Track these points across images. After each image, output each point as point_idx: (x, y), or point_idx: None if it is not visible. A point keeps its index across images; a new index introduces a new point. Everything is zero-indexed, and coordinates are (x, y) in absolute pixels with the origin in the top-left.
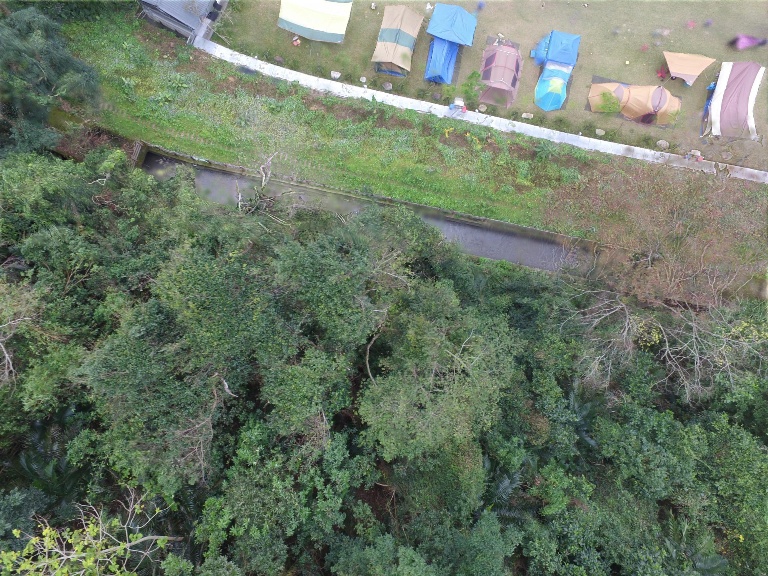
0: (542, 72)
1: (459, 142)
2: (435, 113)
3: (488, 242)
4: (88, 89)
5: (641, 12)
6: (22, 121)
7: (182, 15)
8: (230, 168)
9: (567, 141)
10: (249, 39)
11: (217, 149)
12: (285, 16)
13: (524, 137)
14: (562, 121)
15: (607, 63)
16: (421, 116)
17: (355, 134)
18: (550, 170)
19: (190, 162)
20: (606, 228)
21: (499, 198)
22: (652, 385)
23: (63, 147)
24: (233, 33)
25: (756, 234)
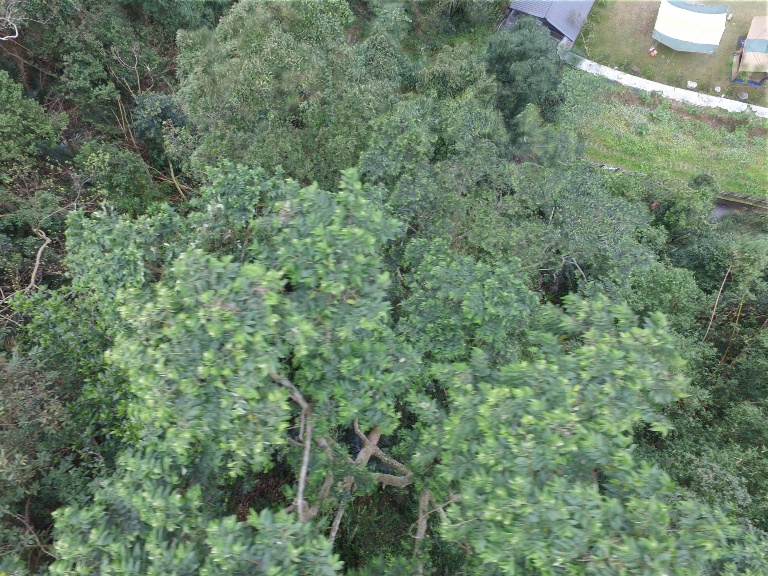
0: None
1: None
2: None
3: None
4: None
5: None
6: None
7: (564, 27)
8: None
9: None
10: (606, 50)
11: (620, 158)
12: (658, 27)
13: None
14: None
15: None
16: None
17: (742, 143)
18: None
19: None
20: None
21: None
22: None
23: None
24: (591, 44)
25: None
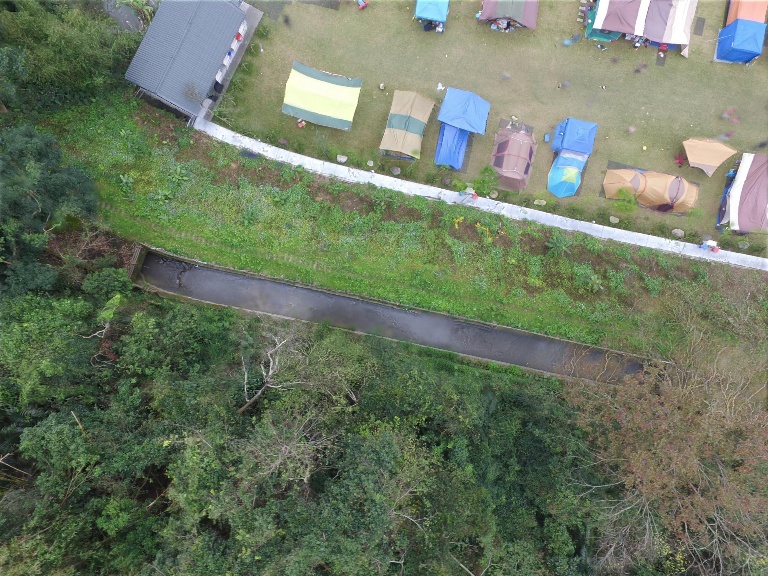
0: (556, 157)
1: (469, 234)
2: (444, 199)
3: (497, 345)
4: (84, 188)
5: (661, 95)
6: (16, 221)
7: (182, 101)
8: (233, 270)
9: (580, 229)
10: (252, 120)
11: (219, 250)
12: (290, 101)
13: (536, 225)
14: (575, 208)
15: (624, 148)
16: (430, 203)
17: (362, 230)
18: (562, 267)
19: (191, 263)
20: (618, 332)
21: (510, 302)
22: (669, 574)
23: (59, 282)
24: (235, 114)
25: None
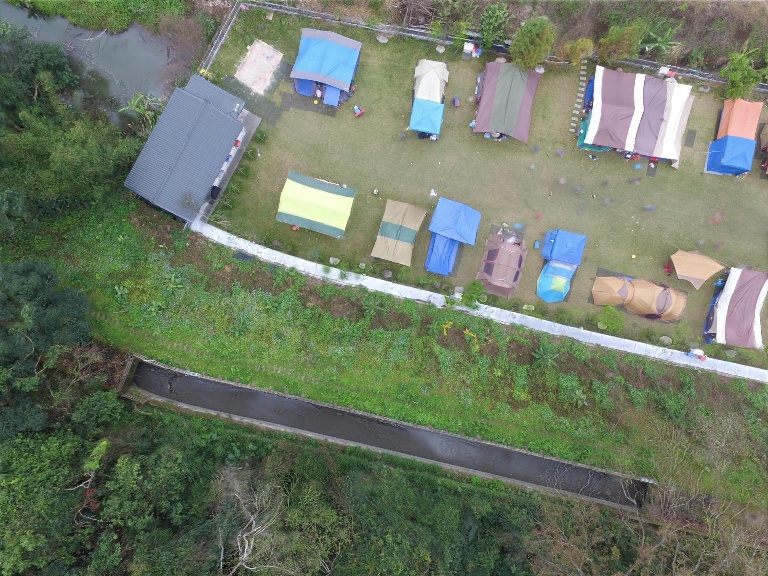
0: (546, 263)
1: (457, 340)
2: (434, 302)
3: (481, 457)
4: None
5: (651, 204)
6: None
7: (179, 210)
8: (222, 380)
9: (568, 334)
10: (247, 222)
11: (210, 360)
12: (284, 209)
13: (524, 331)
14: (564, 314)
15: (613, 256)
16: (420, 307)
17: (351, 340)
18: (548, 378)
19: None
20: (602, 449)
21: (494, 417)
22: None
23: (50, 420)
24: (231, 215)
25: (755, 457)
